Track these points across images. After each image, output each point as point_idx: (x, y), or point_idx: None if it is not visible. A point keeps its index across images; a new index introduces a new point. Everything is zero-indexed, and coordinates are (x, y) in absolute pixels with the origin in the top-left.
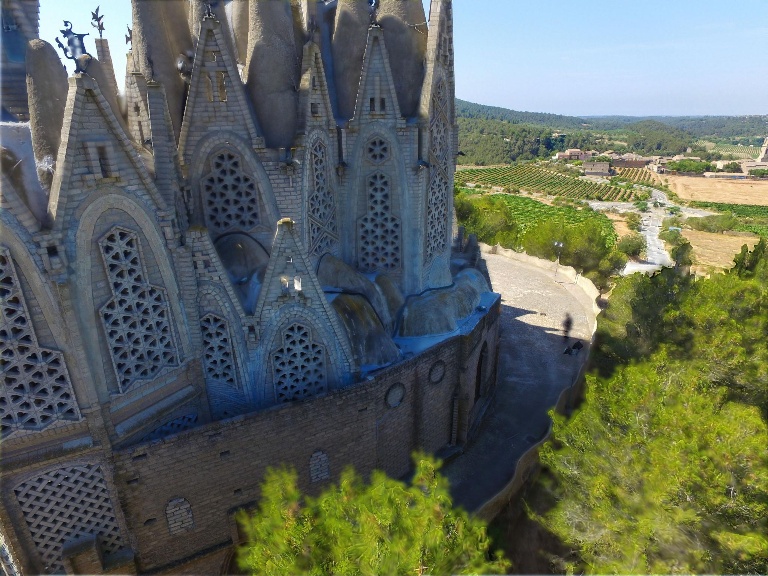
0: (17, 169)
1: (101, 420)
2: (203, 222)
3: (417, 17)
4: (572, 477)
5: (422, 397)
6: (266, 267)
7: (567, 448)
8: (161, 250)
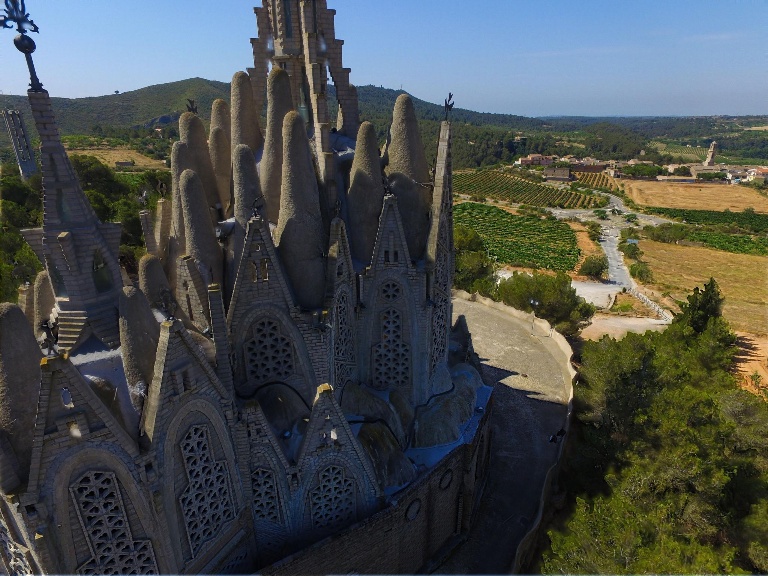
0: (116, 399)
1: None
2: (245, 377)
3: (422, 174)
4: None
5: (434, 503)
6: (304, 418)
7: None
8: (223, 430)
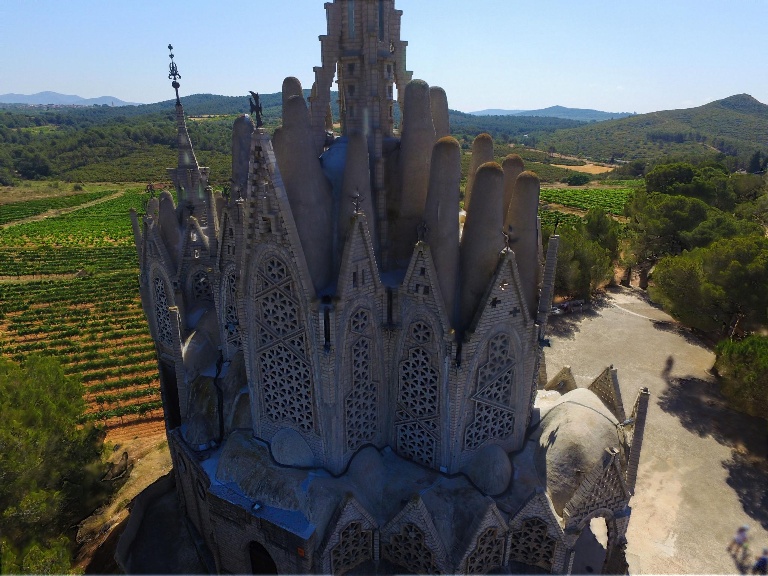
0: None
1: (156, 345)
2: None
3: None
4: None
5: None
6: None
7: None
8: None
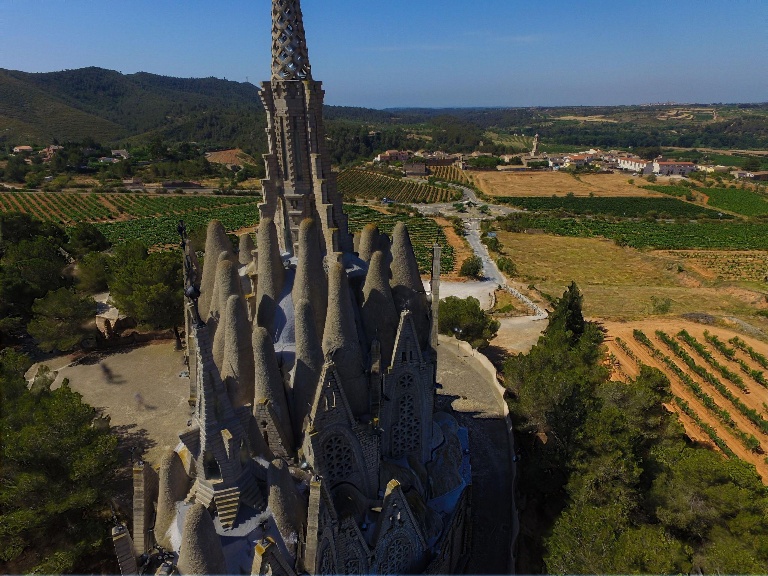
0: None
1: None
2: None
3: (419, 283)
4: (564, 575)
5: None
6: (371, 508)
7: (546, 546)
8: None
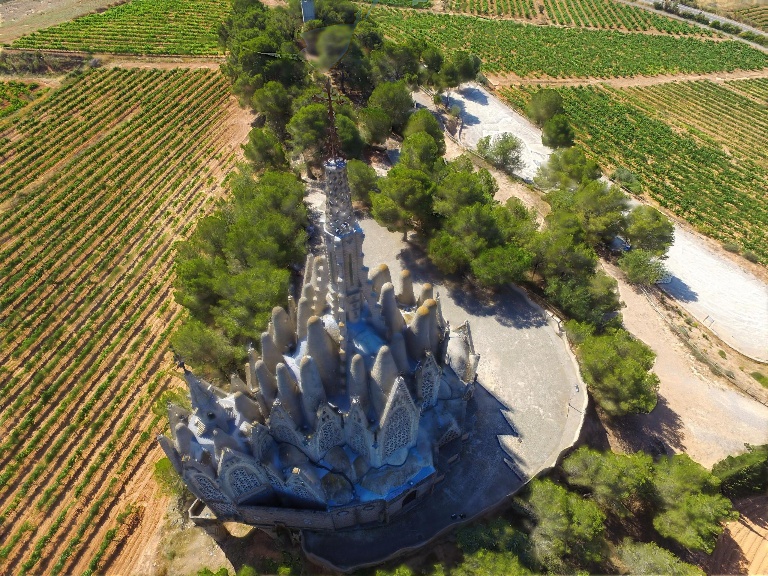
0: None
1: None
2: None
3: (388, 387)
4: None
5: (360, 512)
6: (294, 467)
7: None
8: None
